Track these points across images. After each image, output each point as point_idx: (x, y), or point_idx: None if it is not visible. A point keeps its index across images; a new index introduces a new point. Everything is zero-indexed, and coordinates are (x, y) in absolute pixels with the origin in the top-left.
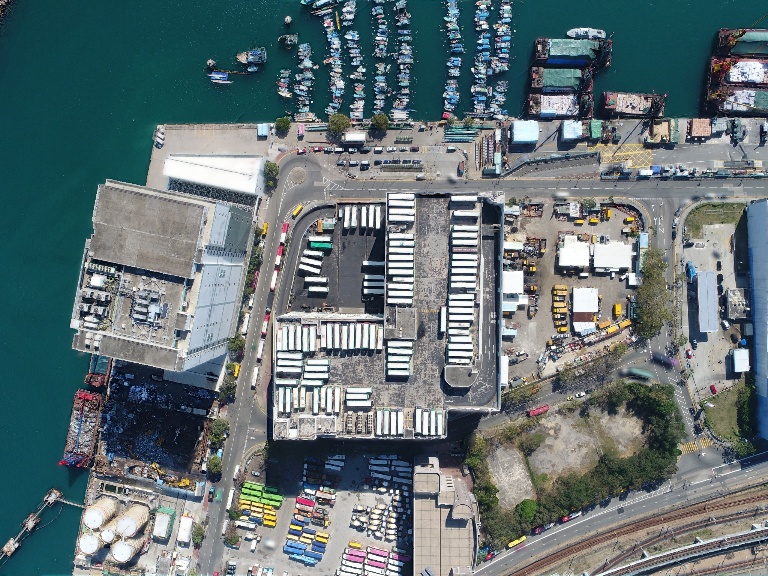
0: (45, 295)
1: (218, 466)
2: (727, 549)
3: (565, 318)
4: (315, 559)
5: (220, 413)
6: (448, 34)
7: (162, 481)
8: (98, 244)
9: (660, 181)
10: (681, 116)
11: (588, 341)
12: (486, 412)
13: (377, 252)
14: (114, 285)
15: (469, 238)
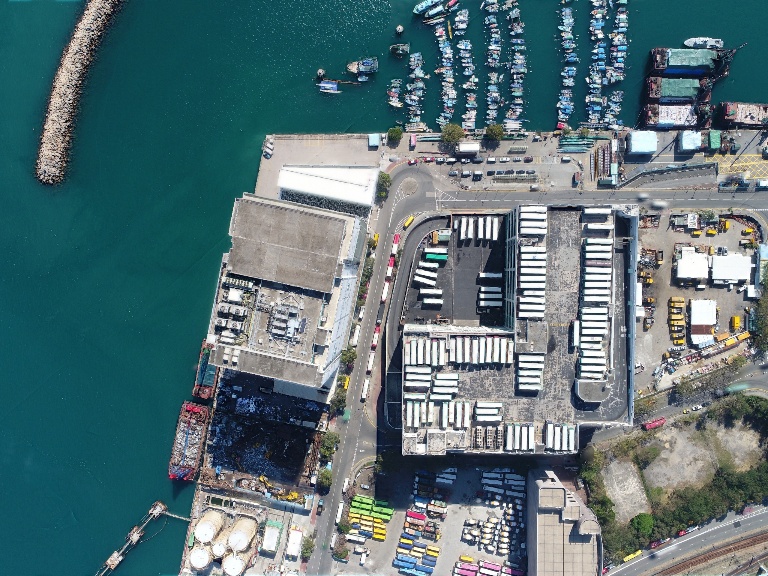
0: (150, 306)
1: (330, 479)
2: None
3: (682, 330)
4: (426, 573)
5: (329, 426)
6: (562, 43)
7: (270, 494)
8: (236, 258)
9: None
10: None
11: (706, 354)
12: (600, 425)
13: (493, 264)
14: (250, 299)
15: (603, 251)
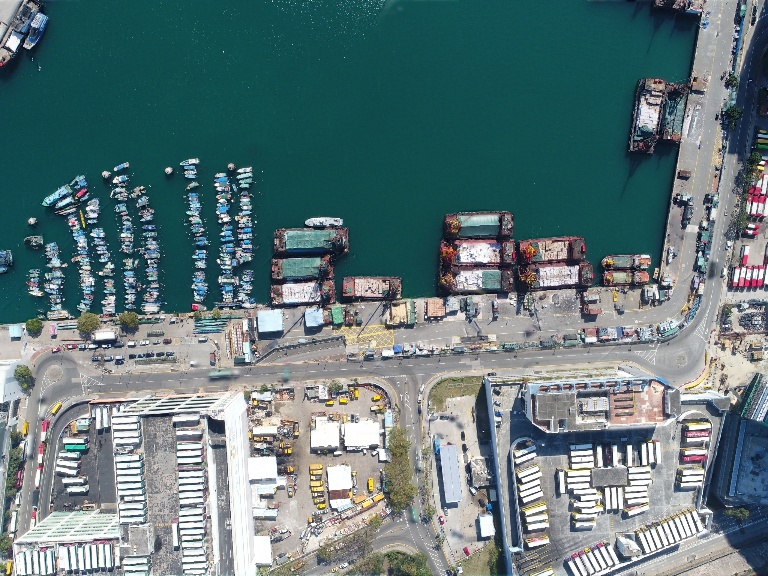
0: None
1: None
2: None
3: (323, 495)
4: None
5: None
6: (191, 228)
7: None
8: None
9: (403, 359)
10: (418, 296)
11: (345, 516)
12: None
13: None
14: None
15: (193, 456)
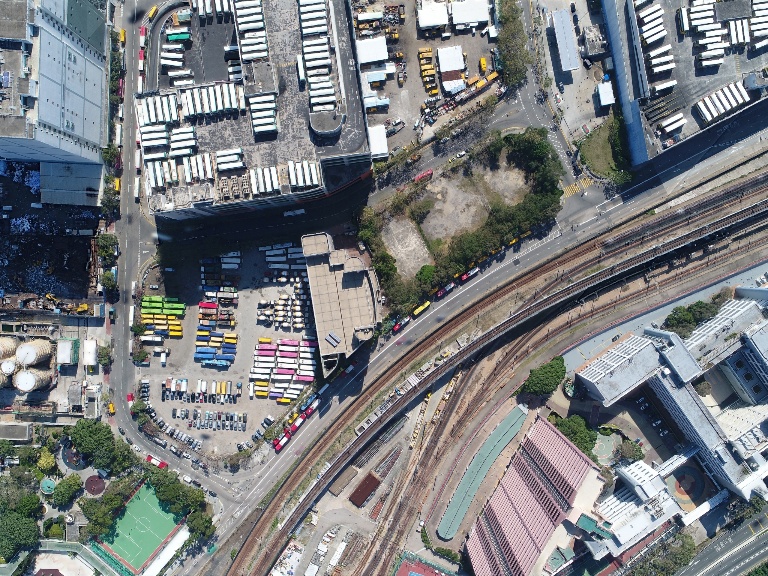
0: None
1: (112, 280)
2: (621, 281)
3: (435, 81)
4: (227, 361)
5: (108, 232)
6: None
7: (59, 310)
8: None
9: None
10: None
11: (459, 99)
12: (373, 187)
13: None
14: None
15: None
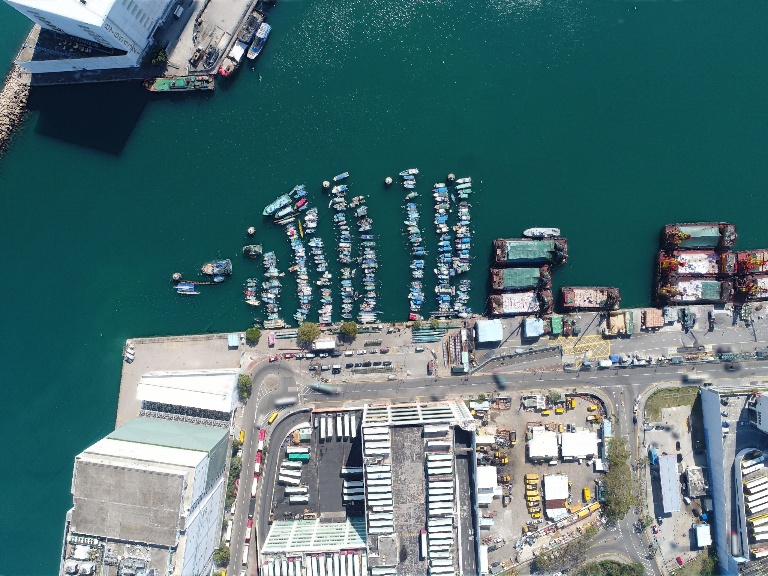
0: (22, 512)
1: None
2: None
3: (538, 504)
4: None
5: None
6: (410, 237)
7: None
8: (79, 519)
9: (619, 369)
10: (635, 307)
11: (561, 526)
12: None
13: (354, 457)
14: (98, 553)
15: (444, 467)
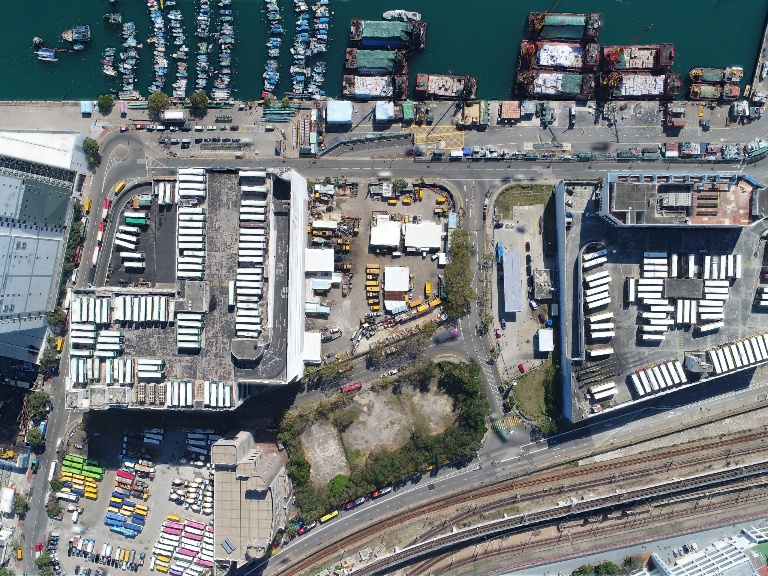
0: None
1: (37, 438)
2: (533, 526)
3: (378, 296)
4: (134, 531)
5: (44, 386)
6: (268, 15)
7: None
8: None
9: (471, 162)
10: (493, 98)
11: (399, 319)
12: (302, 388)
13: None
14: None
15: (256, 213)
